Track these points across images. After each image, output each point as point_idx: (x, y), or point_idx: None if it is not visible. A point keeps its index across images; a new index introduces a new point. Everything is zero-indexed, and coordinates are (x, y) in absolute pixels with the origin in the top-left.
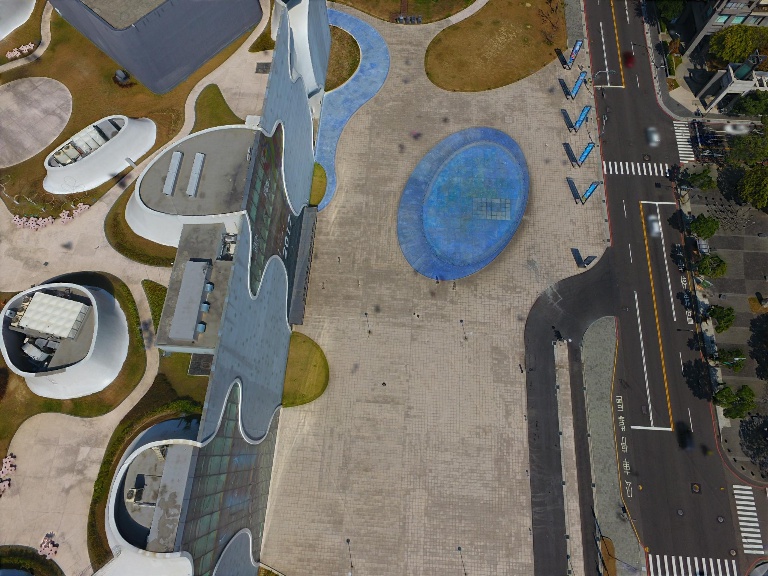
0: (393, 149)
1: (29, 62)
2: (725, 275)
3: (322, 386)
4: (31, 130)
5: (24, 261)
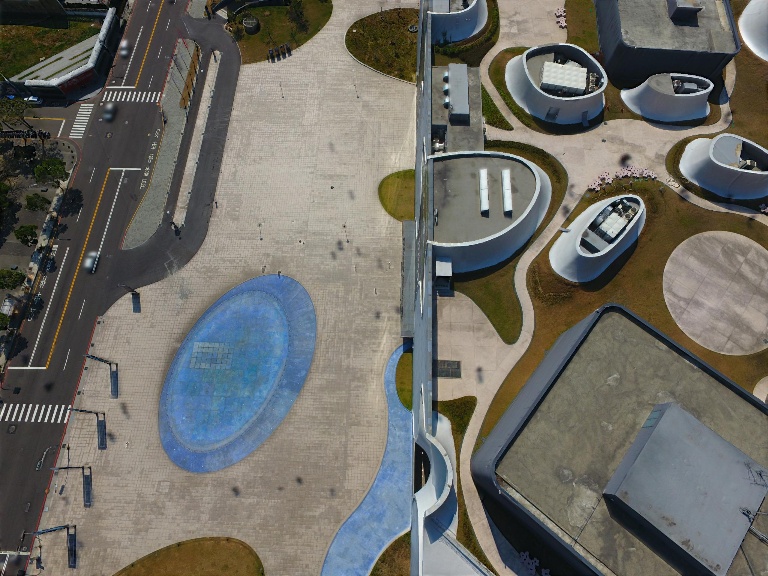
0: (317, 433)
1: (763, 380)
2: (0, 289)
3: (383, 185)
4: (700, 278)
5: (625, 142)
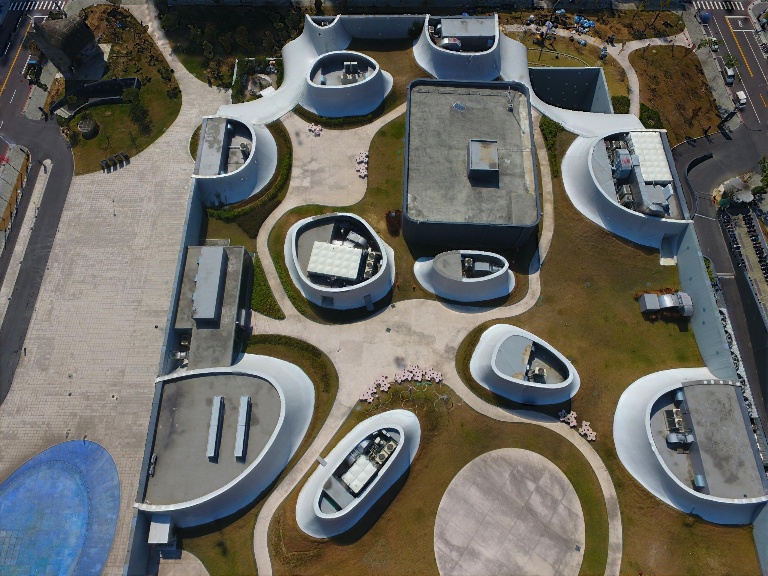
0: None
1: None
2: None
3: None
4: (479, 517)
5: (412, 331)
